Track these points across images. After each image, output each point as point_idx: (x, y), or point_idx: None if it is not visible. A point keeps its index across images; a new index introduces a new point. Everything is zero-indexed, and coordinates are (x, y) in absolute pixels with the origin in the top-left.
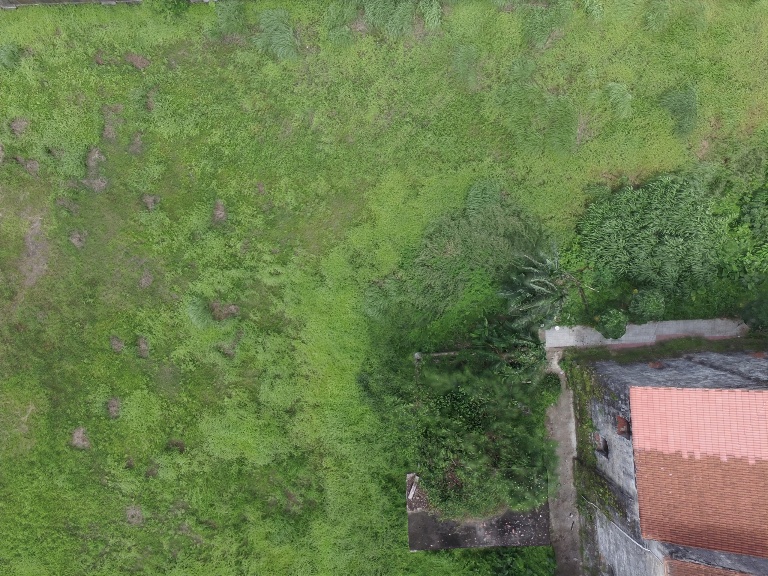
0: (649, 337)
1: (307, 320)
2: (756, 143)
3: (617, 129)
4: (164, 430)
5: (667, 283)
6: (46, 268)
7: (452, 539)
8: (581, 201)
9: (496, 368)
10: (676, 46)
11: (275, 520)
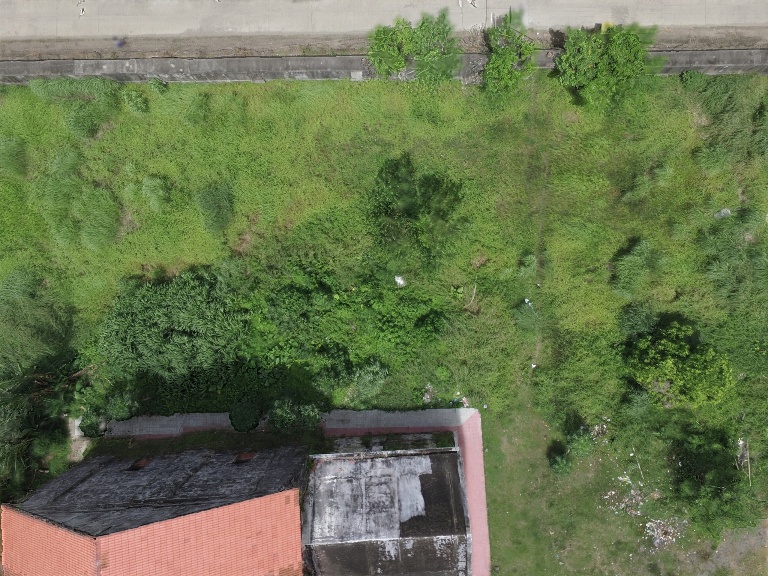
0: (176, 428)
1: None
2: (292, 239)
3: (156, 222)
4: None
5: (175, 379)
6: None
7: None
8: (116, 292)
9: None
10: (217, 141)
11: None
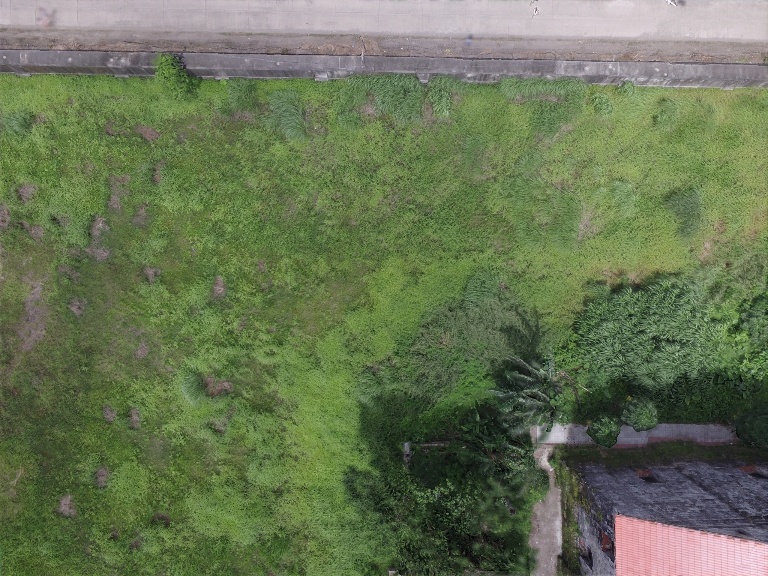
0: (641, 439)
1: (299, 401)
2: (758, 249)
3: (619, 228)
4: (151, 503)
5: (661, 389)
6: (44, 333)
7: None
8: (580, 298)
9: (484, 472)
10: (683, 148)
11: None
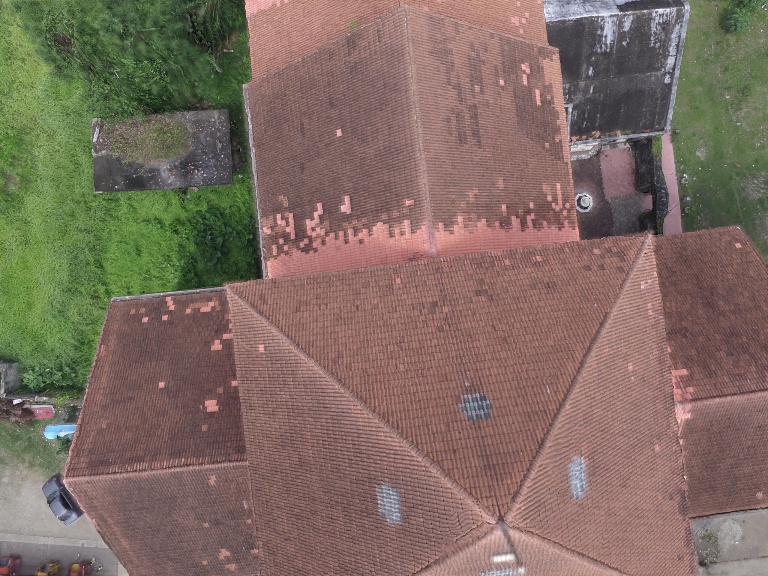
0: None
1: (22, 4)
2: None
3: None
4: None
5: None
6: None
7: (137, 181)
8: None
9: (168, 4)
10: None
11: None
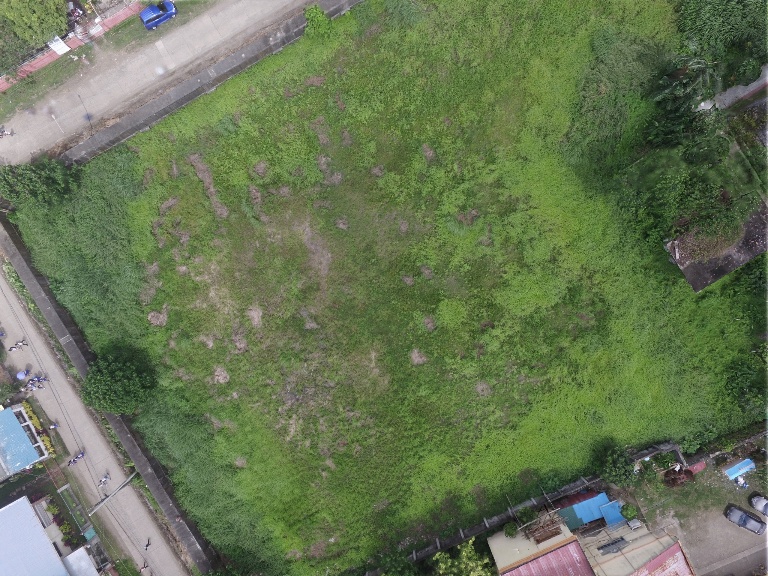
0: (767, 77)
1: (530, 192)
2: None
3: None
4: (473, 319)
5: (764, 30)
6: (330, 256)
7: (720, 271)
8: (671, 11)
9: (691, 139)
10: None
11: (583, 337)
